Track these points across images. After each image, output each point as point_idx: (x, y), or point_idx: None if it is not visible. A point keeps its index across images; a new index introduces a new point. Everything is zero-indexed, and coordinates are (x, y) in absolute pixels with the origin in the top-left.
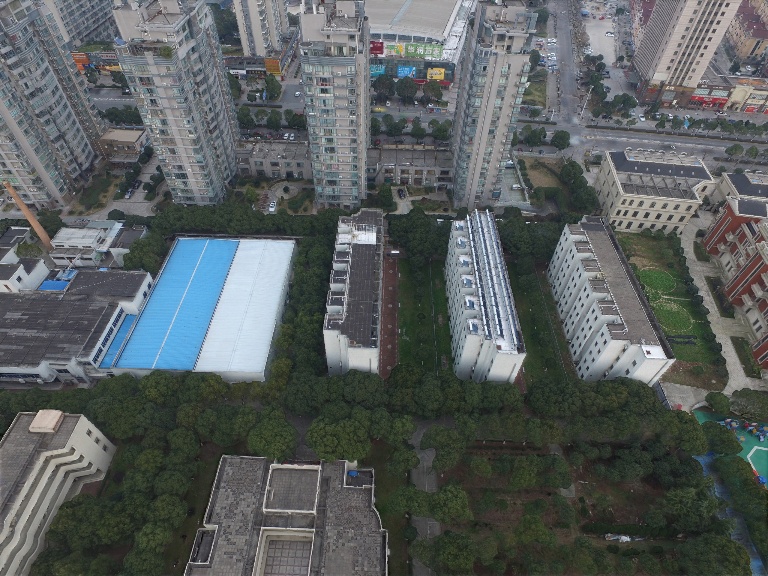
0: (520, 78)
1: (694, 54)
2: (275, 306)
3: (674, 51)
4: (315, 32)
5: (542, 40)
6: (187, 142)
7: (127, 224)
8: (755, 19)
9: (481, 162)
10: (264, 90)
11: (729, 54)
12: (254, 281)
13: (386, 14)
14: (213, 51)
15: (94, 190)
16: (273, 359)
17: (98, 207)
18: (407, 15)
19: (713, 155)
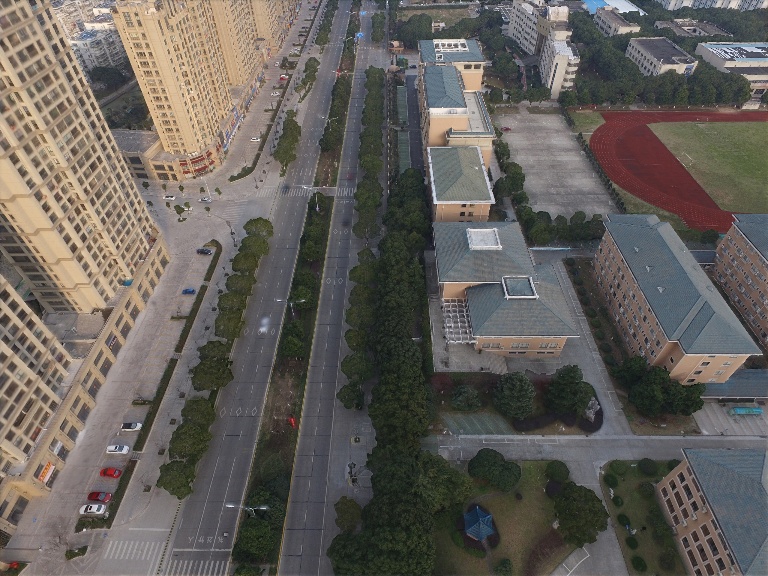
0: None
1: None
2: None
3: None
4: None
5: None
6: None
7: (545, 1)
8: None
9: None
10: None
11: None
12: None
13: None
14: None
15: None
16: None
17: None
18: None
19: None
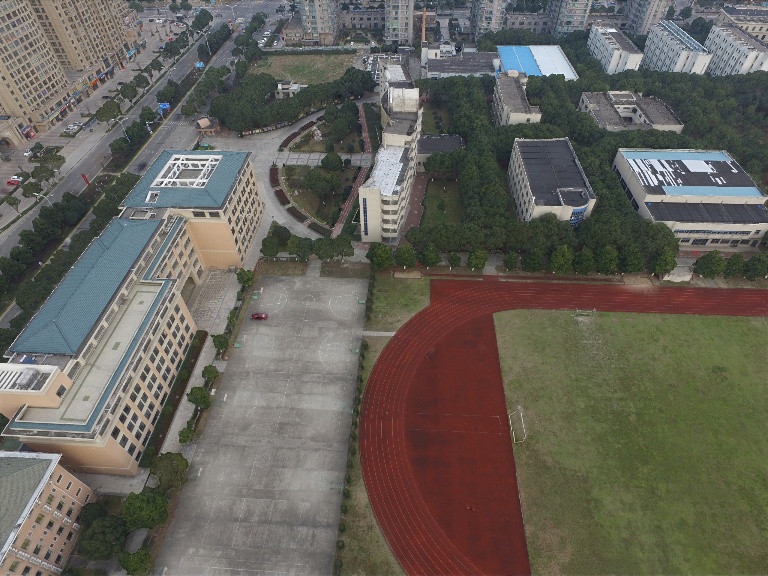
0: None
1: None
2: (567, 64)
3: None
4: None
5: None
6: None
7: (458, 46)
8: None
9: (656, 7)
10: None
11: None
12: (550, 57)
13: None
14: None
15: None
16: (580, 75)
17: None
18: None
19: None
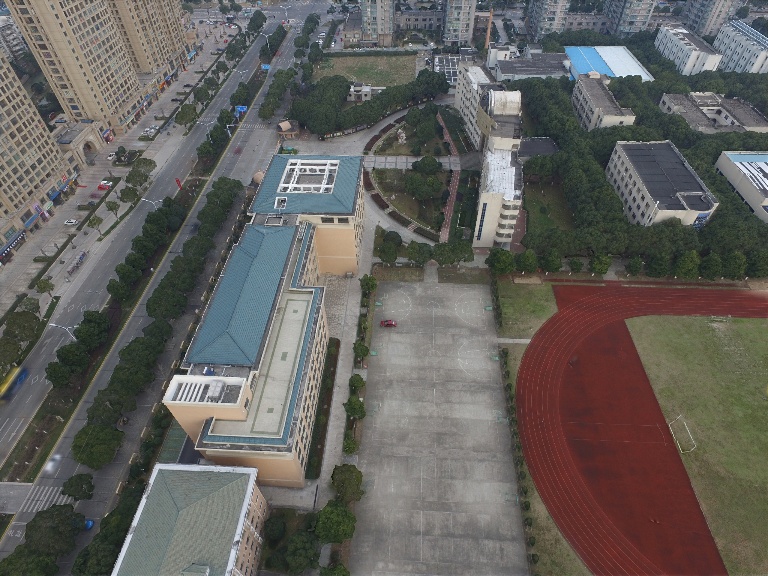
0: None
1: None
2: (637, 65)
3: None
4: None
5: None
6: None
7: (520, 47)
8: None
9: (720, 7)
10: None
11: None
12: (618, 58)
13: None
14: None
15: (480, 39)
16: (655, 76)
17: None
18: None
19: None
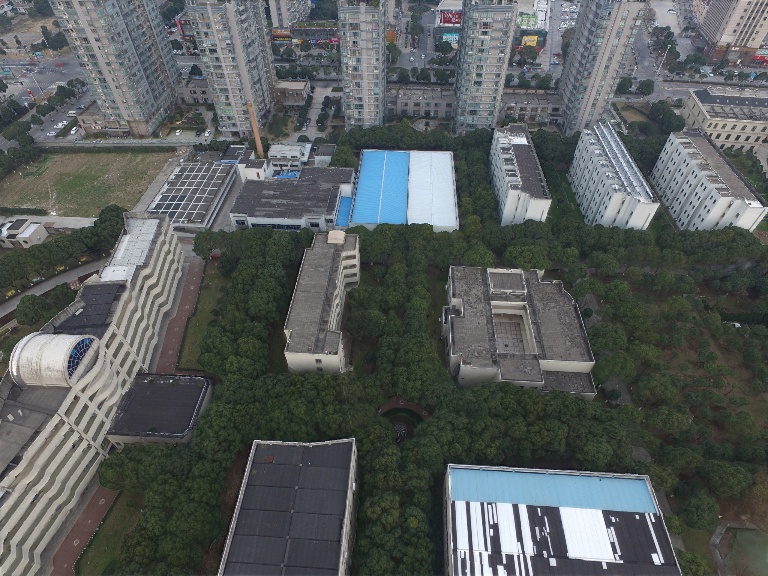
0: (635, 22)
1: (758, 18)
2: (452, 191)
3: (740, 16)
4: None
5: None
6: (371, 77)
7: (316, 144)
8: None
9: (594, 94)
10: (388, 55)
11: None
12: (431, 176)
13: None
14: None
15: (278, 124)
16: (463, 219)
17: (285, 136)
18: None
19: None
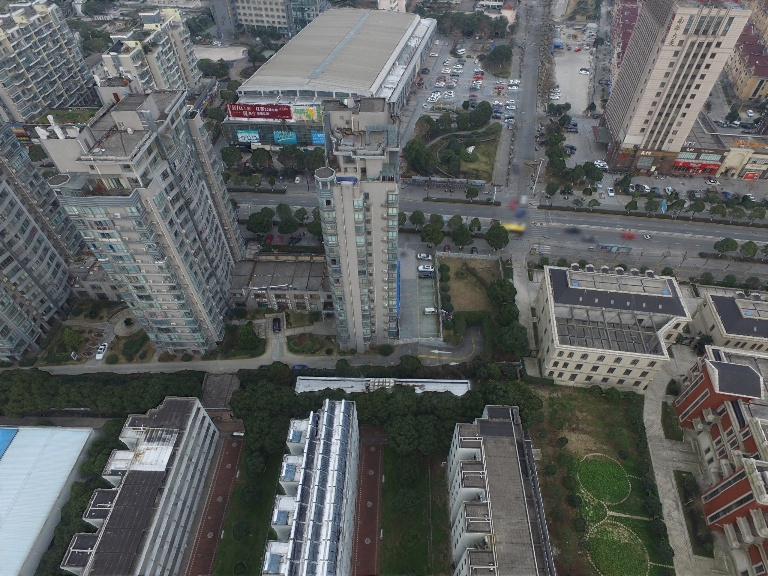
0: (387, 209)
1: (674, 114)
2: (20, 562)
3: (648, 110)
4: (72, 161)
5: (502, 82)
6: None
7: None
8: (758, 50)
9: (359, 304)
10: None
11: (727, 94)
12: (7, 511)
13: (309, 63)
14: (1, 160)
15: None
16: None
17: None
18: (333, 64)
19: (699, 248)
